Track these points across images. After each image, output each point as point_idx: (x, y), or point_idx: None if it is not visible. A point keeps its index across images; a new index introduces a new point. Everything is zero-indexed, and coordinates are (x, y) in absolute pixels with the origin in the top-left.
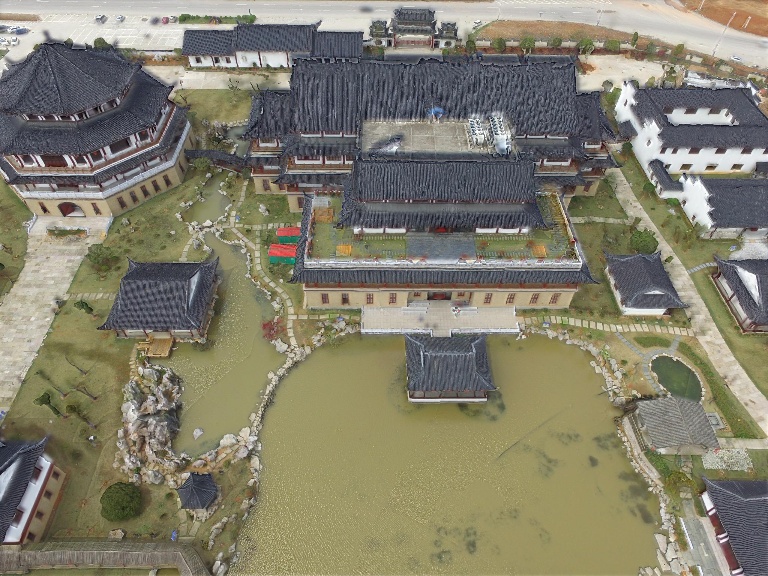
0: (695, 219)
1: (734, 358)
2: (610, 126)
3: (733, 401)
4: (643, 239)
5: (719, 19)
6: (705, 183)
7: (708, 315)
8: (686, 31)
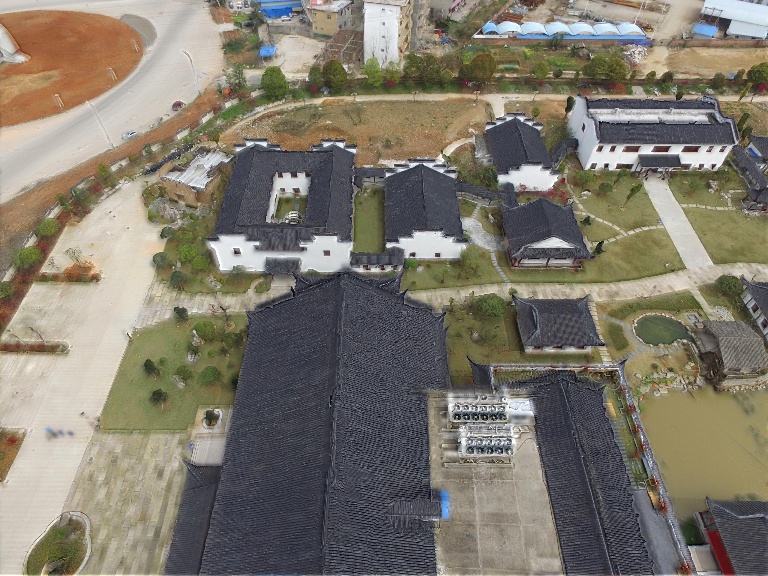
0: (441, 254)
1: (611, 283)
2: (244, 280)
3: (660, 299)
4: (496, 304)
5: (28, 117)
6: (426, 229)
7: (564, 285)
8: (38, 150)
